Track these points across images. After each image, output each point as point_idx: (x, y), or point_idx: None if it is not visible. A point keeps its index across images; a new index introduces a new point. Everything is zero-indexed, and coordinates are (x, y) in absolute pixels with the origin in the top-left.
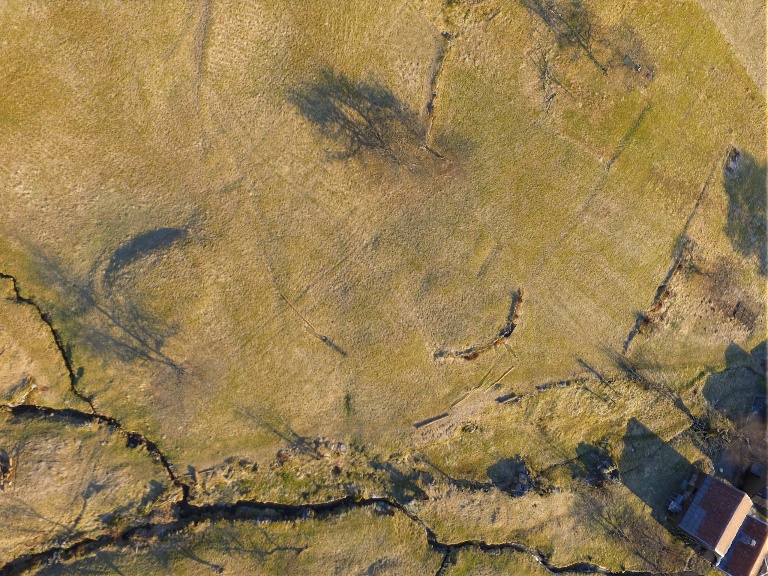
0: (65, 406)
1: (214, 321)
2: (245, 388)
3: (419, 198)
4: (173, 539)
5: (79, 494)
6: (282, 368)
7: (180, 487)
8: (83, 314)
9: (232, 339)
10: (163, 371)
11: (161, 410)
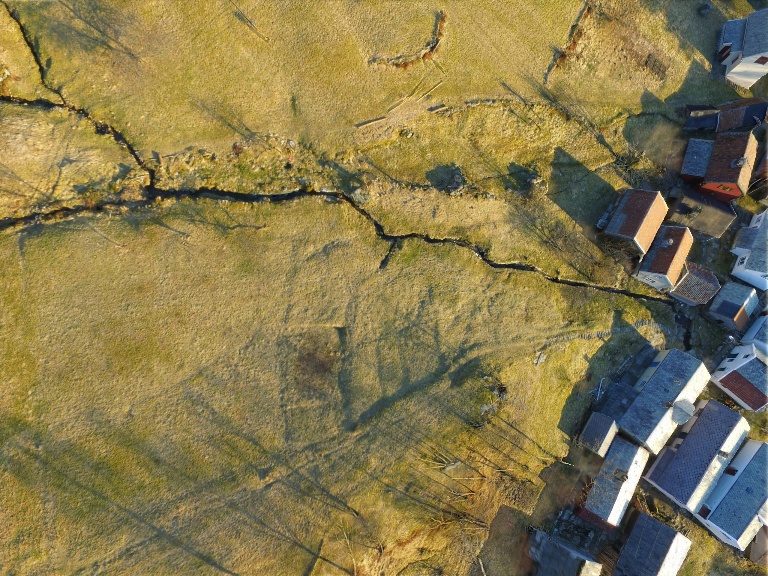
0: (37, 96)
1: (165, 14)
2: (198, 80)
3: None
4: (143, 212)
5: (55, 164)
6: (231, 64)
7: (147, 172)
8: (47, 7)
9: (183, 32)
10: (123, 60)
11: (124, 100)
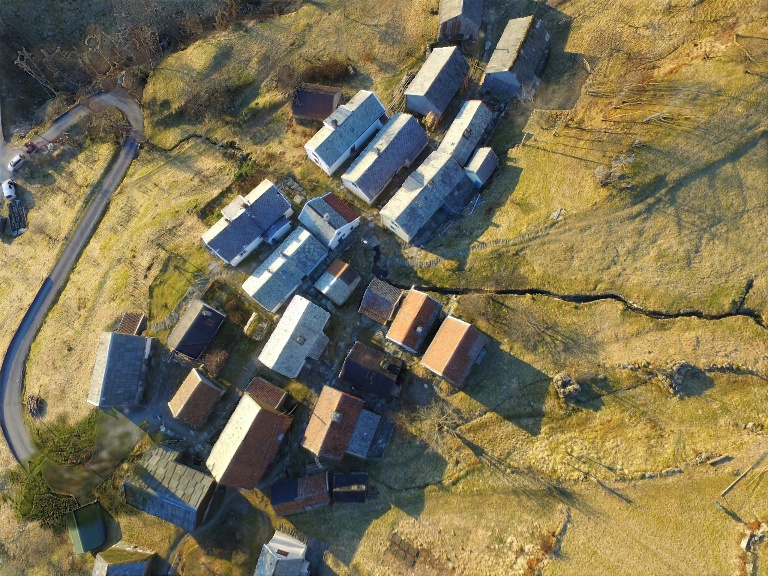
0: None
1: None
2: None
3: None
4: None
5: None
6: None
7: None
8: None
9: None
10: None
11: None
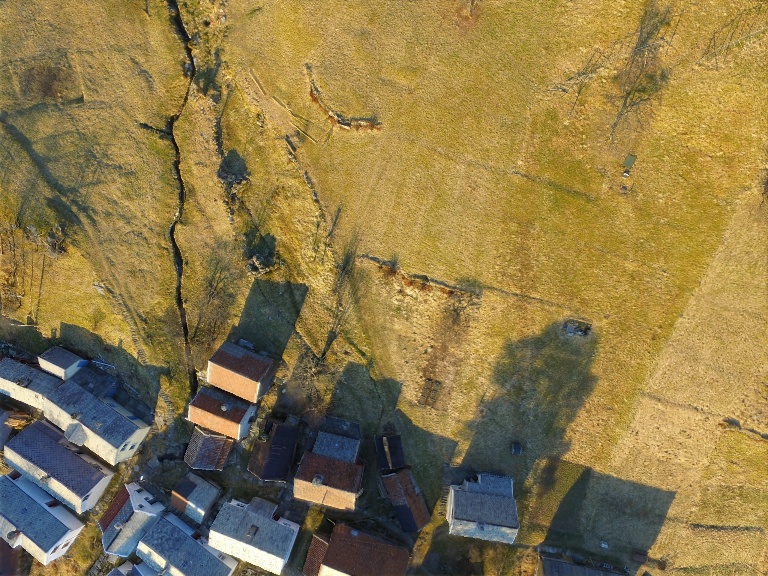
0: None
1: None
2: None
3: (431, 2)
4: None
5: None
6: None
7: None
8: None
9: None
10: None
11: None
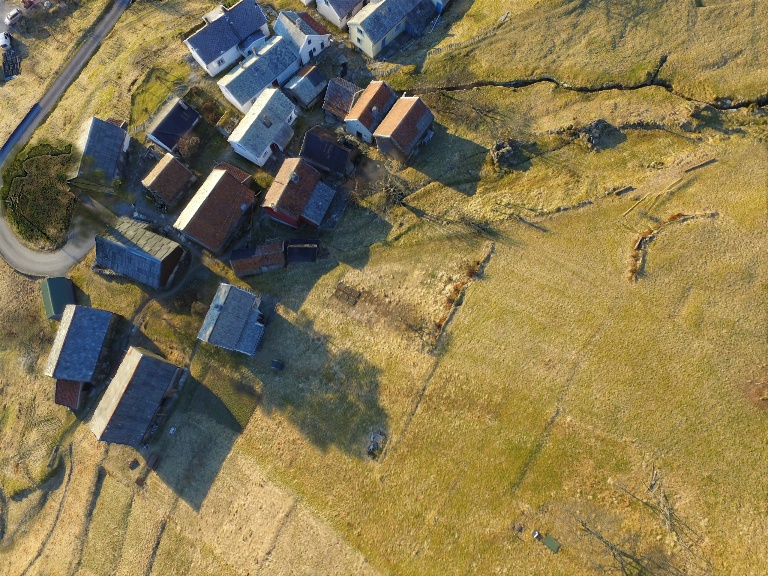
0: None
1: None
2: None
3: None
4: None
5: None
6: None
7: None
8: None
9: None
10: None
11: None
